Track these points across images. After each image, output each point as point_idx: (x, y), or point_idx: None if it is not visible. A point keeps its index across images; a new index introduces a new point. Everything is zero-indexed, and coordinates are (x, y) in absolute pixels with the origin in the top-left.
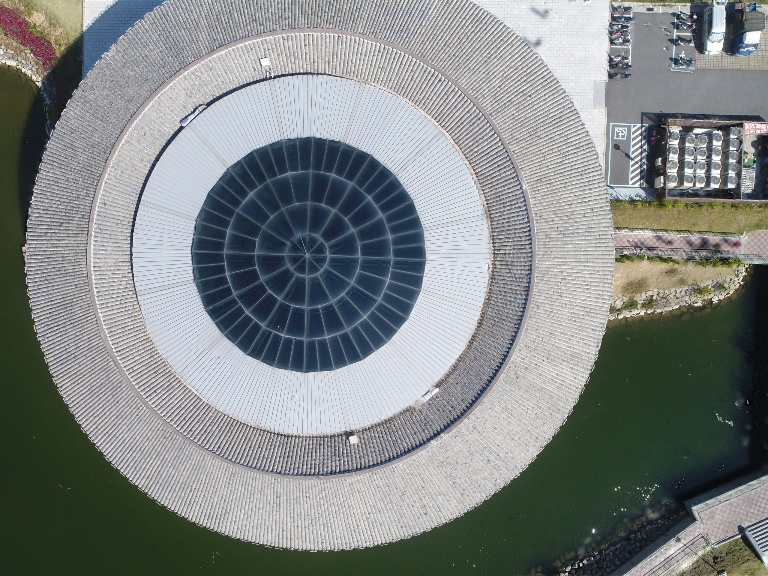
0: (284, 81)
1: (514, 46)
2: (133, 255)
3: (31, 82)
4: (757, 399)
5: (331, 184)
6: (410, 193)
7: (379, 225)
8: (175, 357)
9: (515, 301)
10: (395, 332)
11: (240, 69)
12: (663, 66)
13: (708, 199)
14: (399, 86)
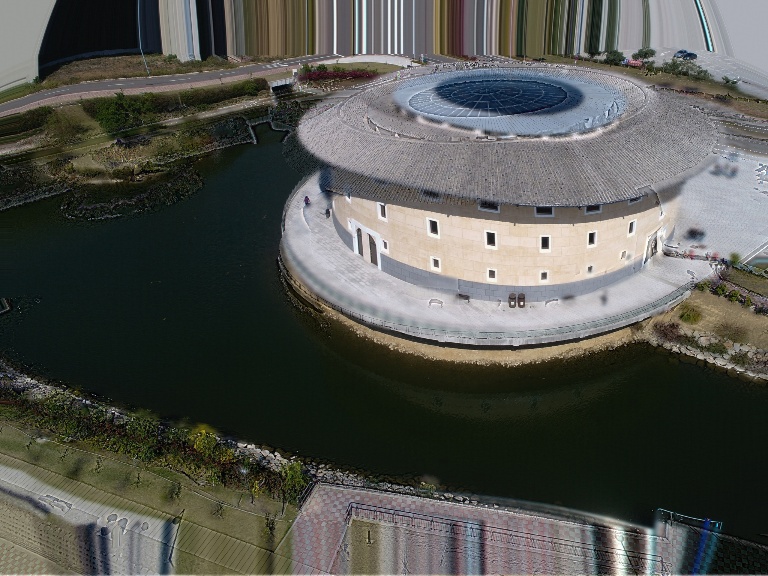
0: None
1: None
2: None
3: None
4: None
5: (528, 86)
6: None
7: None
8: None
9: None
10: (499, 116)
11: None
12: None
13: None
14: None
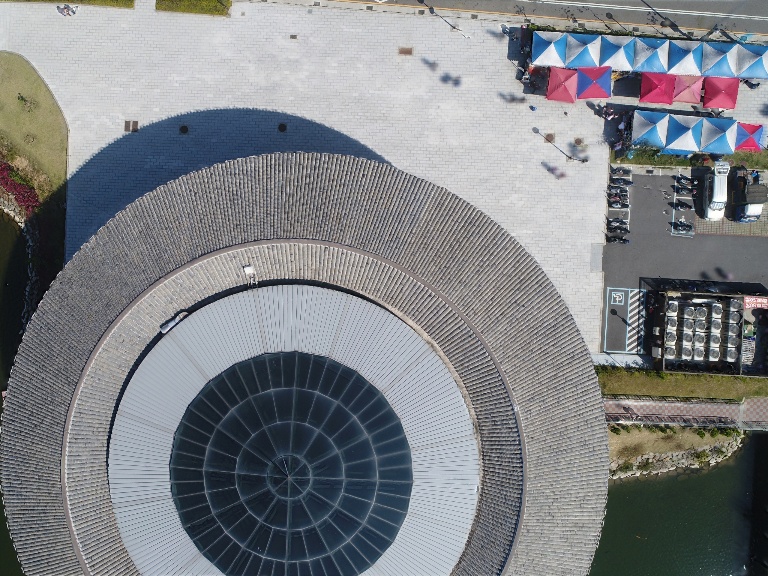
0: (268, 291)
1: (508, 250)
2: (109, 466)
3: (14, 222)
4: (754, 565)
5: (315, 402)
6: (397, 412)
7: (365, 446)
8: (151, 573)
9: (505, 524)
10: (380, 556)
11: (223, 275)
12: (662, 230)
13: (707, 374)
14: (388, 296)
